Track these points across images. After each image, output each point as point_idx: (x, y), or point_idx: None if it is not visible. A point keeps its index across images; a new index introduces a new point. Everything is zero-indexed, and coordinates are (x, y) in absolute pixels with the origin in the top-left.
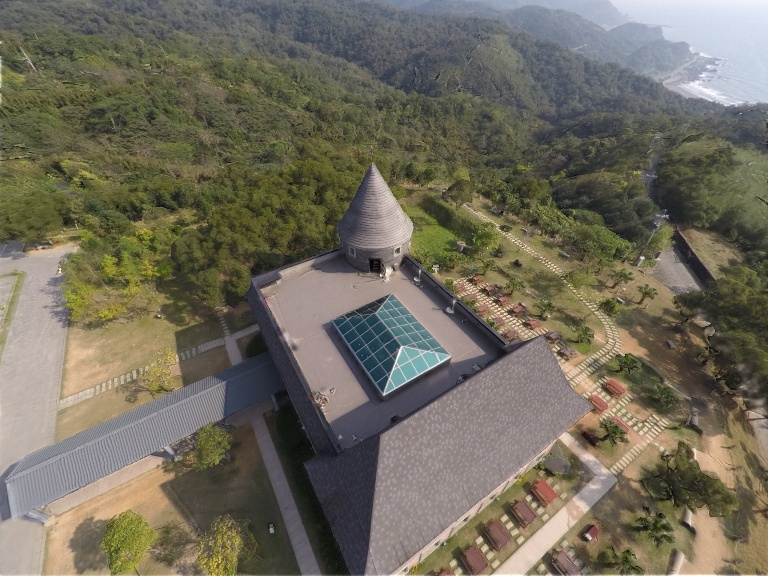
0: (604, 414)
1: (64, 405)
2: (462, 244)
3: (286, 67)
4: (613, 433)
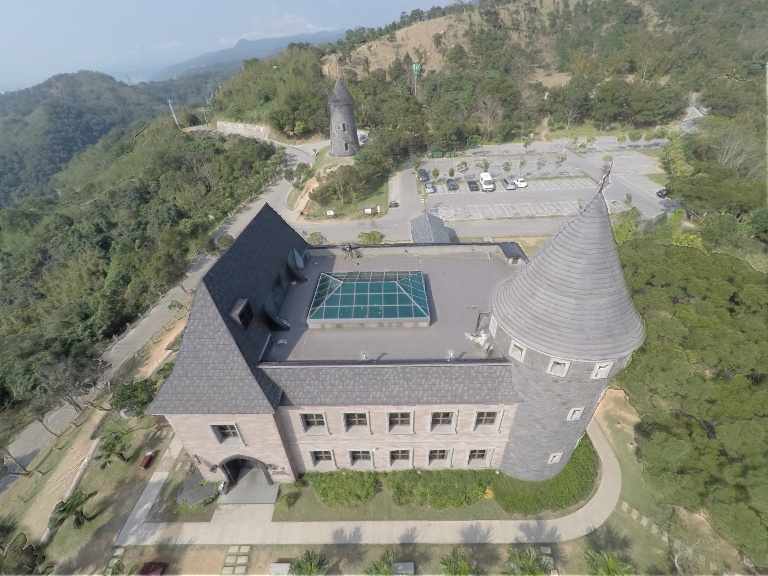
0: None
1: (486, 239)
2: None
3: None
4: (117, 572)
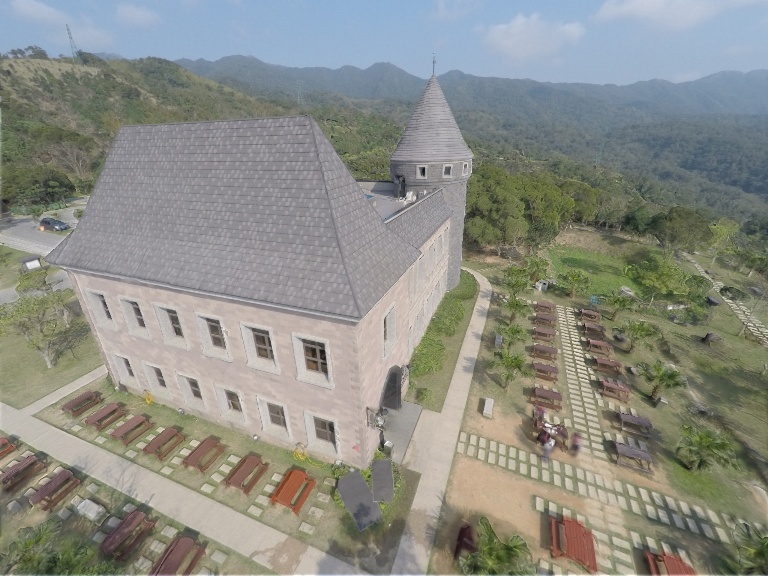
0: (568, 571)
1: None
2: (628, 291)
3: (635, 177)
4: None
